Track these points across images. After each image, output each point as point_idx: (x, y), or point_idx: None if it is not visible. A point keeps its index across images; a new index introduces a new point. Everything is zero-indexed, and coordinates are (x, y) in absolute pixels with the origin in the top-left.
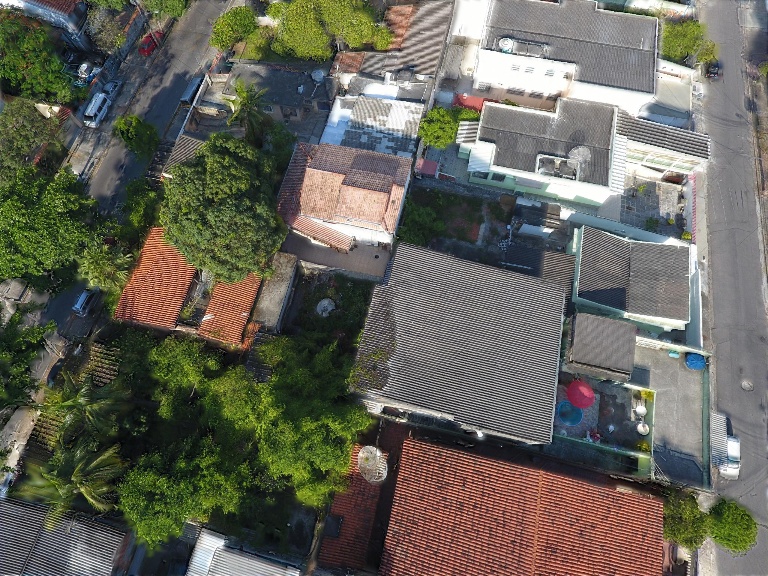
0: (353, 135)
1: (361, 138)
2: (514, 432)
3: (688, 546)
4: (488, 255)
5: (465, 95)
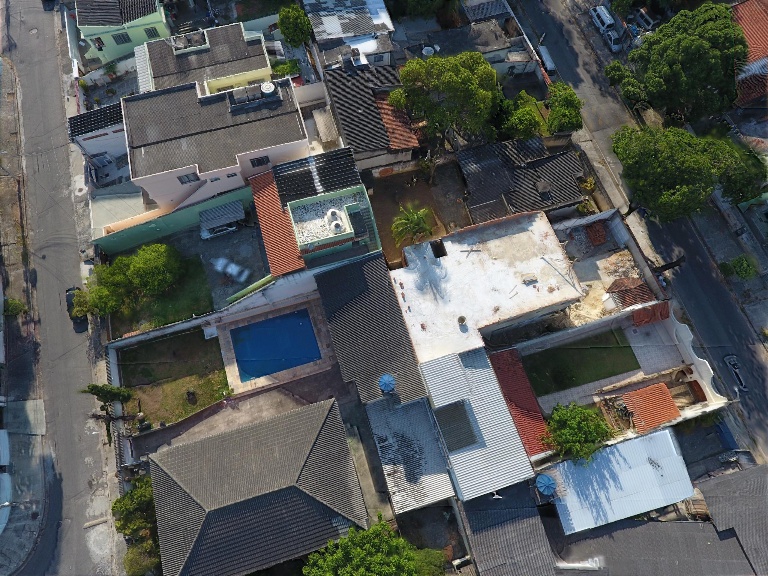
0: (358, 3)
1: (350, 3)
2: None
3: None
4: (224, 1)
5: (294, 84)
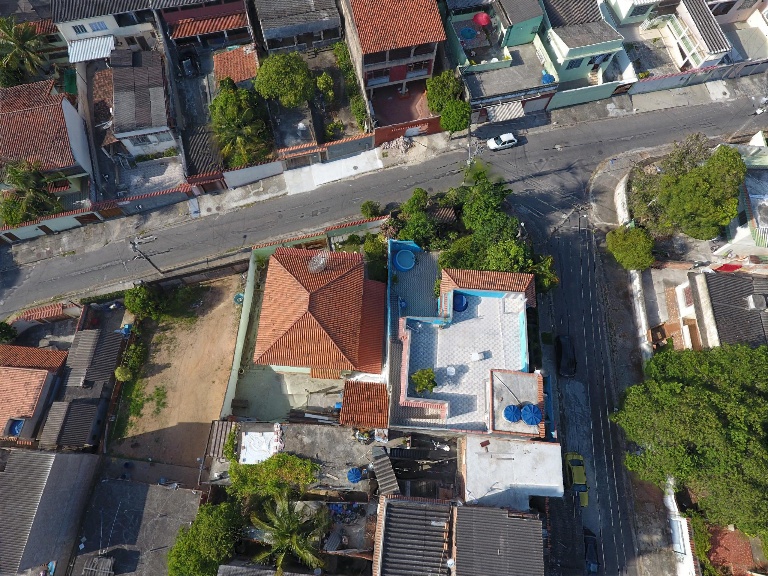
0: None
1: None
2: None
3: None
4: None
5: None
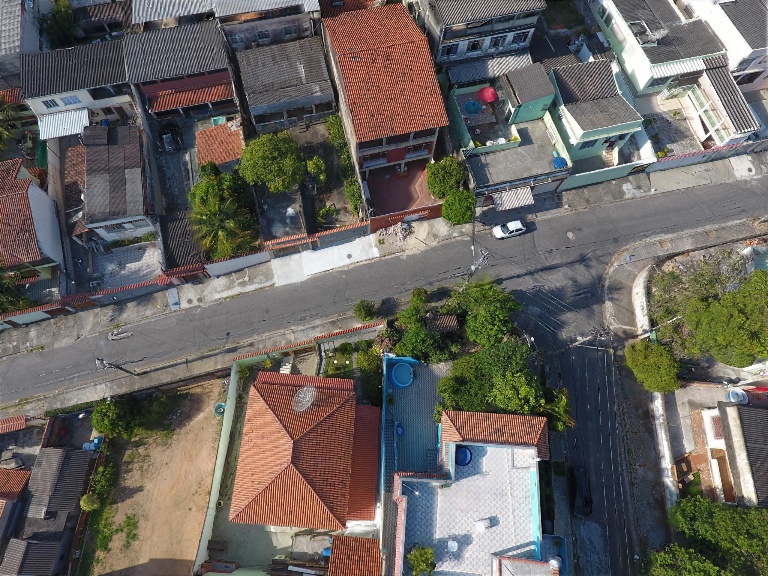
0: None
1: None
2: (440, 6)
3: (433, 173)
4: None
5: None
